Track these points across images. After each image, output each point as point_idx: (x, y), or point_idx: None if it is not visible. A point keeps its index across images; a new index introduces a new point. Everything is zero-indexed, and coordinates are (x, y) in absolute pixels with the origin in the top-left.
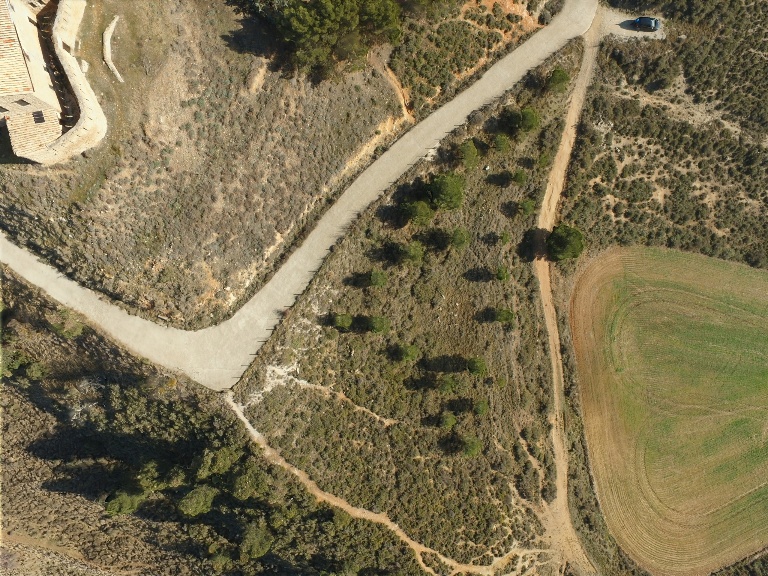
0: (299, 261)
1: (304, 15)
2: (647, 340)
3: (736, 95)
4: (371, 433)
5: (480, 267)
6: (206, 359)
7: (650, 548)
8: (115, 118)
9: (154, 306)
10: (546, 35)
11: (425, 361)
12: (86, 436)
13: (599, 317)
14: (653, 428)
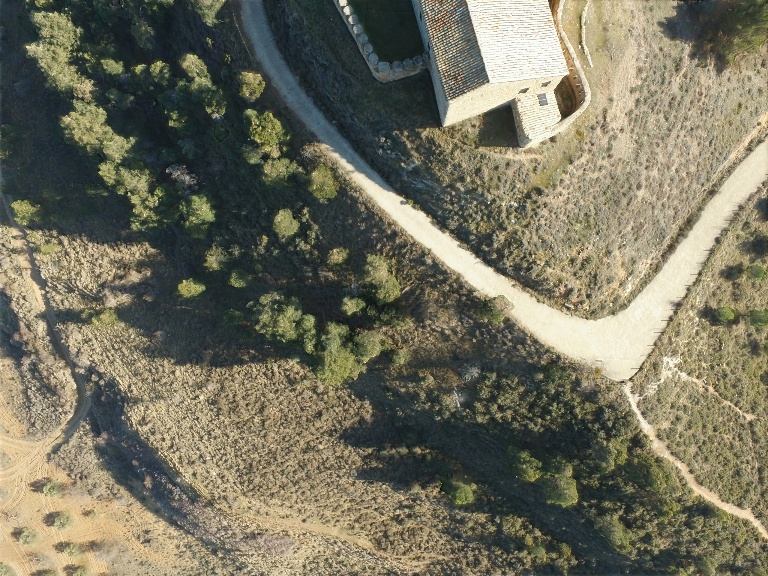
0: (686, 252)
1: None
2: None
3: None
4: (737, 428)
5: None
6: (607, 349)
7: None
8: None
9: (568, 294)
10: None
11: None
12: (406, 425)
13: None
14: None
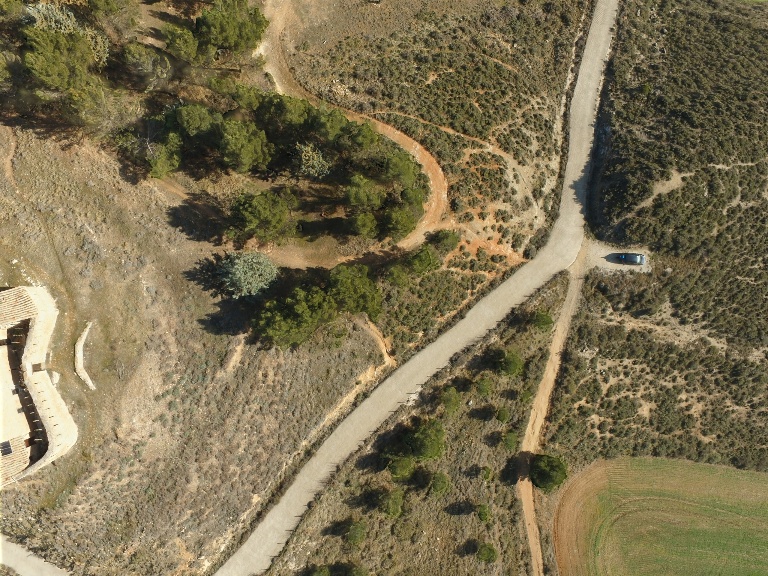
0: (276, 519)
1: (280, 326)
2: (632, 550)
3: (722, 317)
4: None
5: (462, 500)
6: None
7: None
8: (86, 425)
9: None
10: (531, 270)
11: None
12: None
13: (583, 531)
14: None
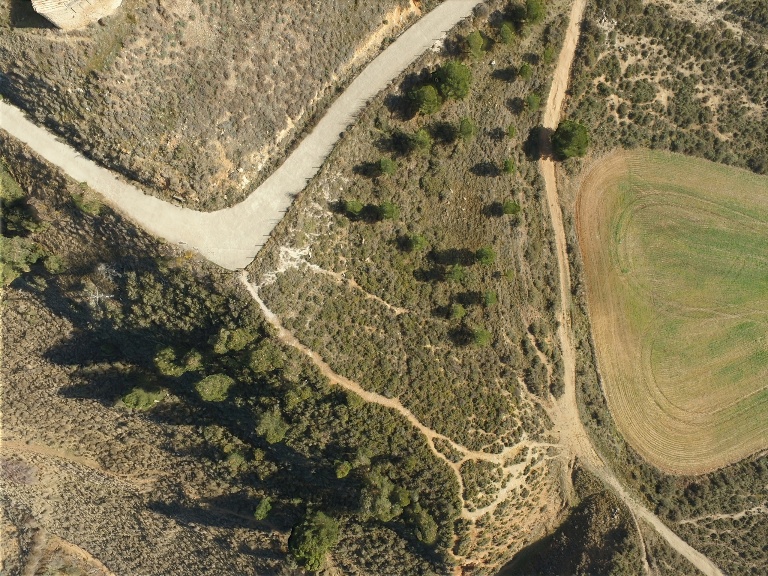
0: (310, 147)
1: None
2: (652, 243)
3: None
4: (382, 320)
5: (487, 162)
6: (221, 239)
7: (657, 444)
8: None
9: (169, 184)
10: None
11: (434, 253)
12: (102, 339)
13: (604, 219)
14: (659, 329)
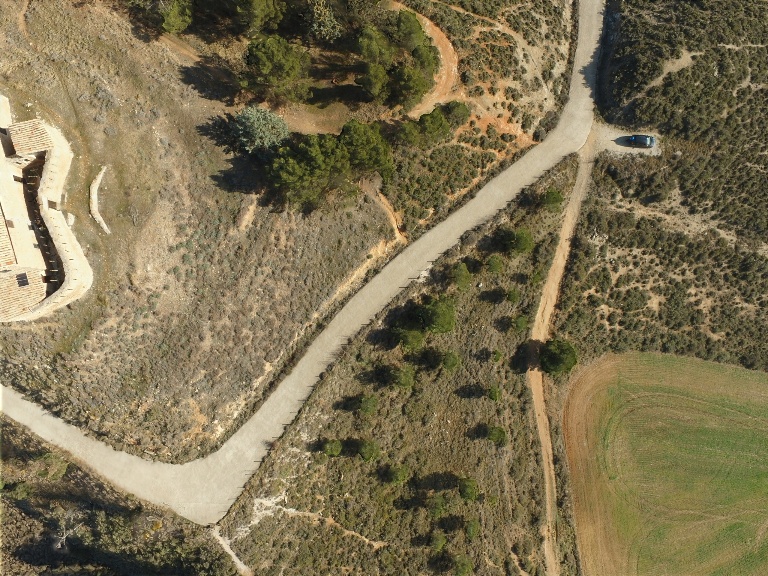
0: (288, 389)
1: (294, 168)
2: (641, 446)
3: (732, 206)
4: (360, 558)
5: (472, 383)
6: (193, 493)
7: None
8: (101, 269)
9: (140, 443)
10: (541, 152)
11: (416, 480)
12: (73, 544)
13: (592, 425)
14: (646, 536)
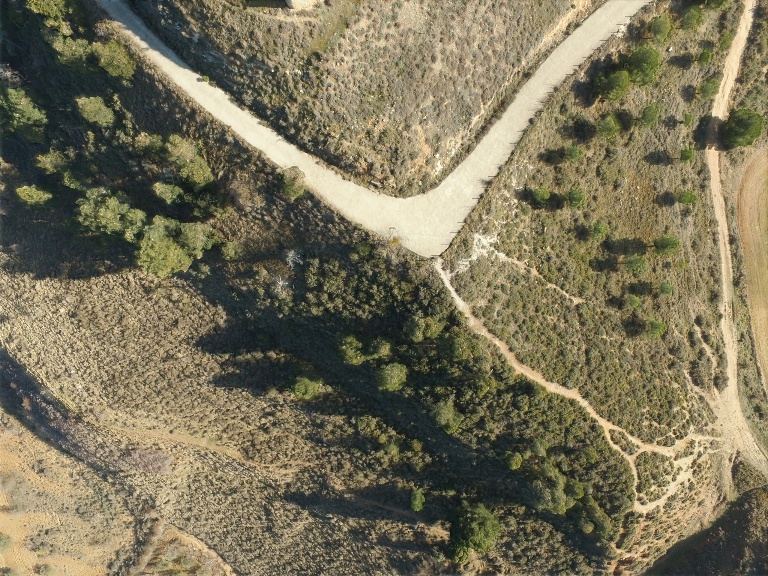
0: (500, 133)
1: None
2: None
3: None
4: (562, 310)
5: (661, 150)
6: (416, 226)
7: None
8: None
9: (371, 169)
10: None
11: (609, 243)
12: (258, 328)
13: (764, 210)
14: None
